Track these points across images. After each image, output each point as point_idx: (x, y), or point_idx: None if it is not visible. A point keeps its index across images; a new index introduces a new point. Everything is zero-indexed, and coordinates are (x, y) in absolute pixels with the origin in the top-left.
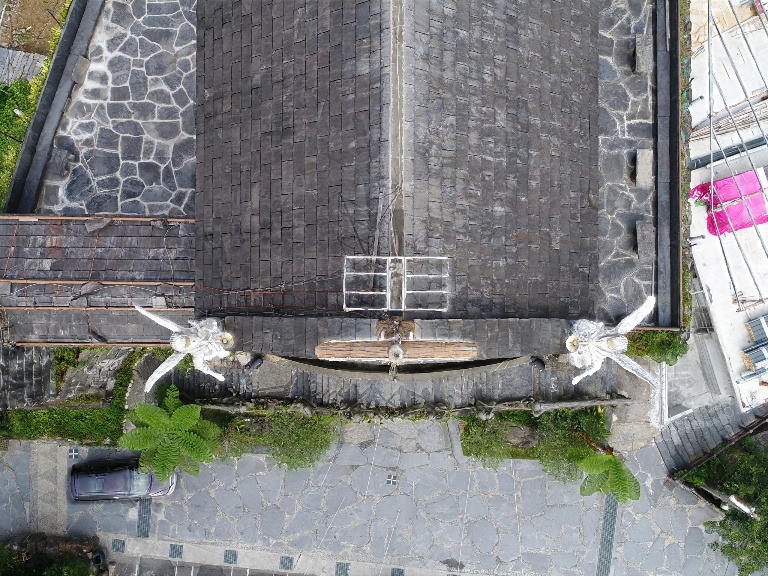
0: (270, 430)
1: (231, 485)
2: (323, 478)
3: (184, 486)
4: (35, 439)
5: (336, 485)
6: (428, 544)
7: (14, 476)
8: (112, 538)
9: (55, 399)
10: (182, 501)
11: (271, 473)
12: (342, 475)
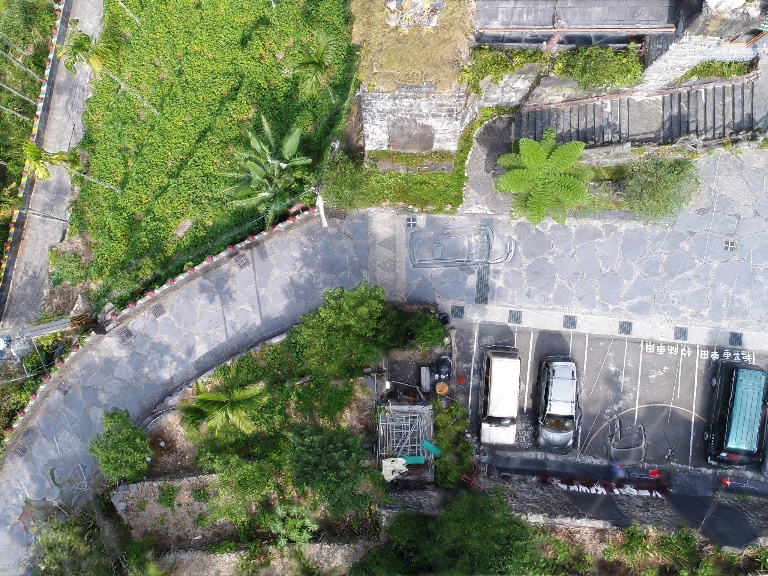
0: (634, 180)
1: (569, 252)
2: (661, 245)
3: (522, 253)
4: (375, 206)
5: (674, 251)
6: (766, 309)
7: (352, 244)
8: (451, 304)
9: (460, 123)
10: (520, 268)
11: (609, 240)
12: (680, 242)
